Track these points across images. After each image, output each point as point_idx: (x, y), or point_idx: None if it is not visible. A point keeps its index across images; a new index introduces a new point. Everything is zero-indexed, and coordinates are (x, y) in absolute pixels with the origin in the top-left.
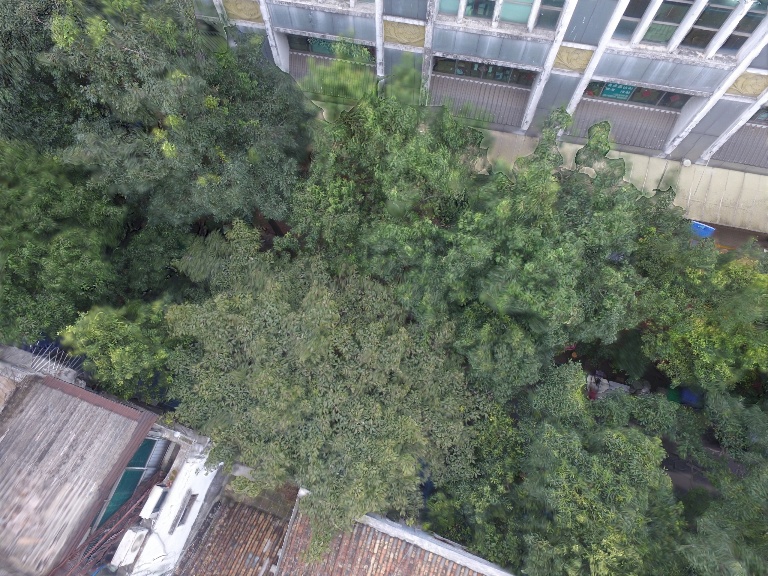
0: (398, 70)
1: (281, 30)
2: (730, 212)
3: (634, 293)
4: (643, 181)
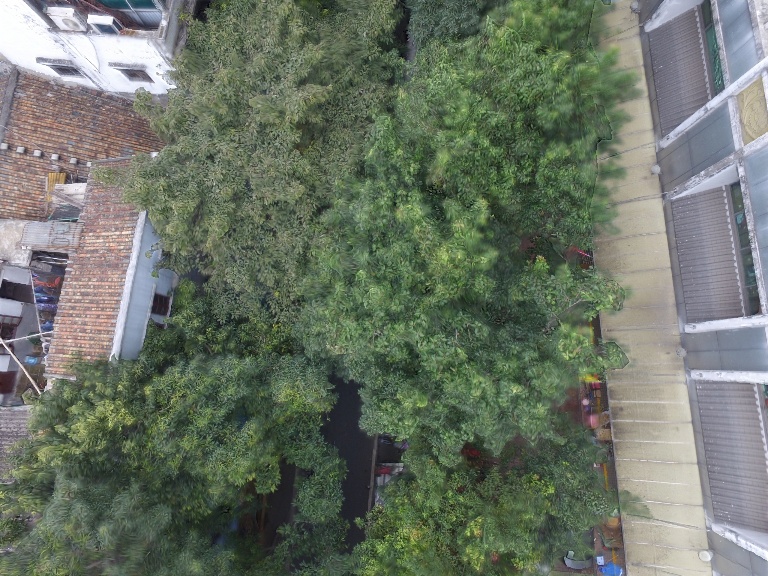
0: (707, 136)
1: None
2: None
3: (407, 436)
4: (663, 501)
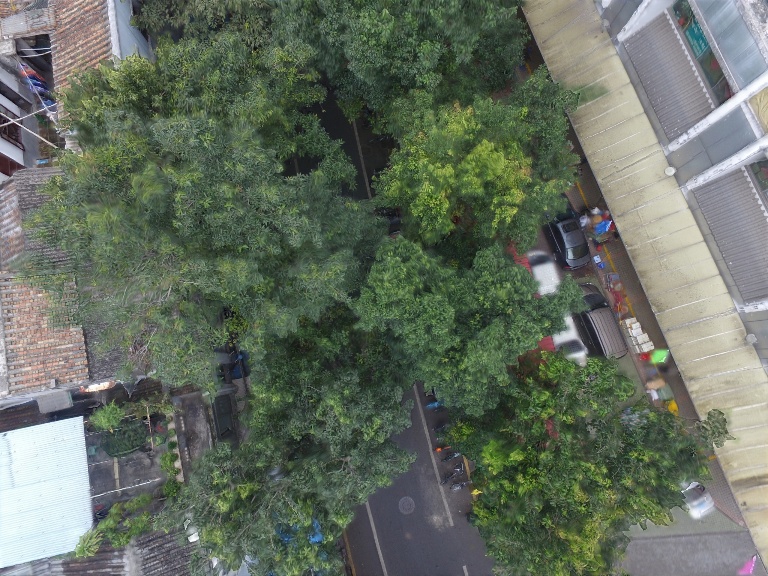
0: None
1: None
2: (649, 254)
3: (388, 30)
4: (627, 155)
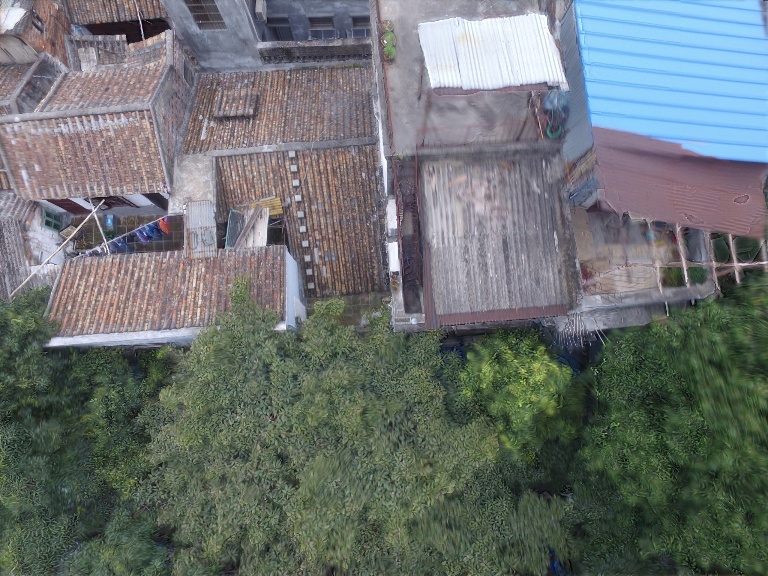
0: None
1: None
2: None
3: None
4: None
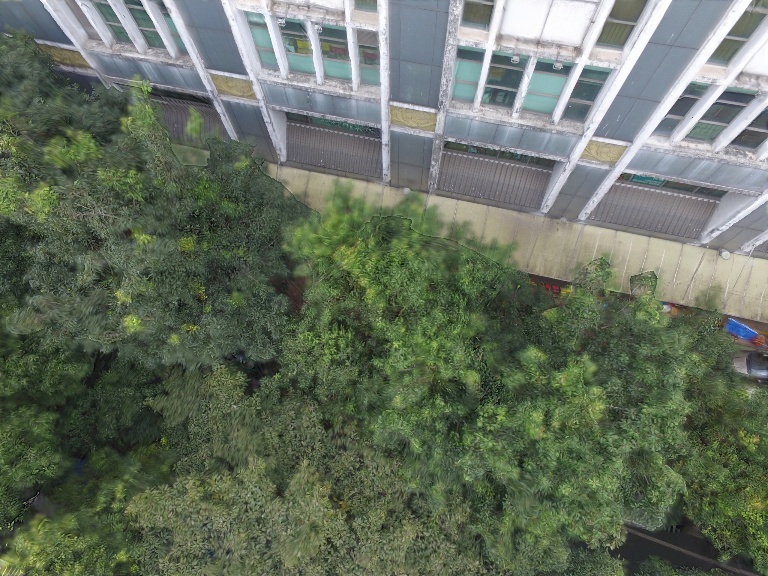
0: (405, 151)
1: (276, 108)
2: None
3: (684, 482)
4: (675, 270)
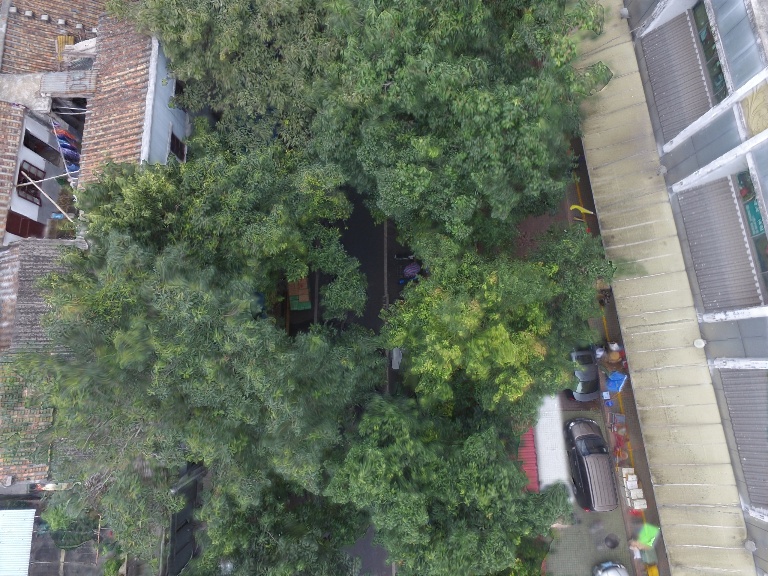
0: None
1: None
2: (660, 420)
3: (423, 187)
4: (658, 309)
